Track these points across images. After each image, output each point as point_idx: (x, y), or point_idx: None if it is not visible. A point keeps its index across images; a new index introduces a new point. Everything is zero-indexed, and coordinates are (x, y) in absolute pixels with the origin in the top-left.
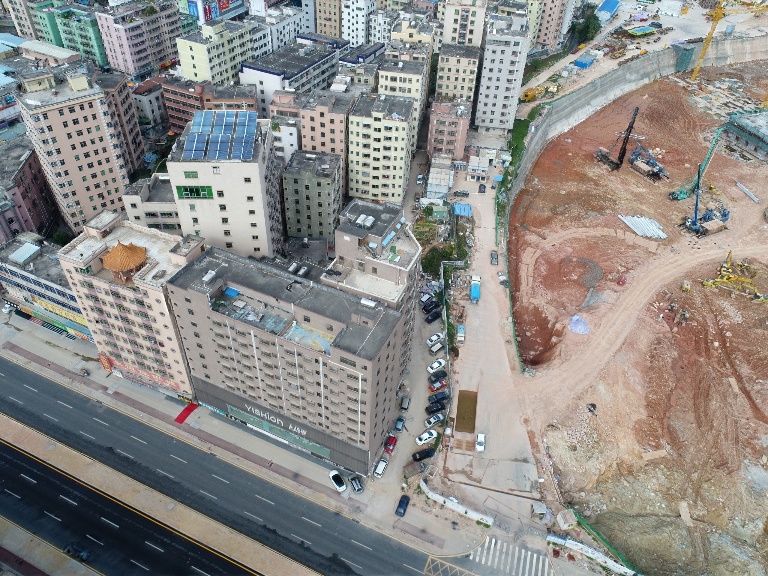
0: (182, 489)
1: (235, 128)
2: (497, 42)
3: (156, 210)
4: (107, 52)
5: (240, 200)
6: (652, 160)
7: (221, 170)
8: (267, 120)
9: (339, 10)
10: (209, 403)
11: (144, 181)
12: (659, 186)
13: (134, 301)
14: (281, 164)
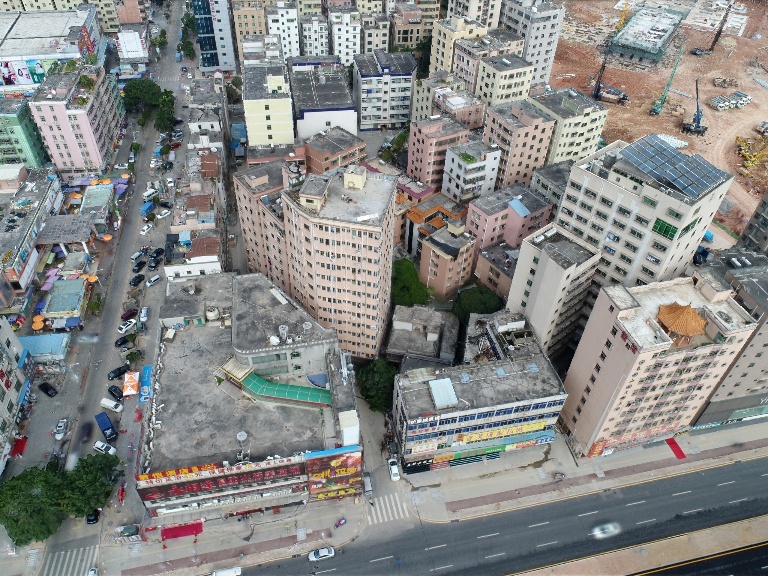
0: (765, 501)
1: (664, 154)
2: (540, 19)
3: (580, 272)
4: (50, 151)
5: (706, 219)
6: (613, 89)
7: (714, 195)
8: (618, 141)
9: (265, 27)
10: (708, 422)
11: (551, 249)
12: (630, 108)
13: (706, 356)
14: (524, 189)
